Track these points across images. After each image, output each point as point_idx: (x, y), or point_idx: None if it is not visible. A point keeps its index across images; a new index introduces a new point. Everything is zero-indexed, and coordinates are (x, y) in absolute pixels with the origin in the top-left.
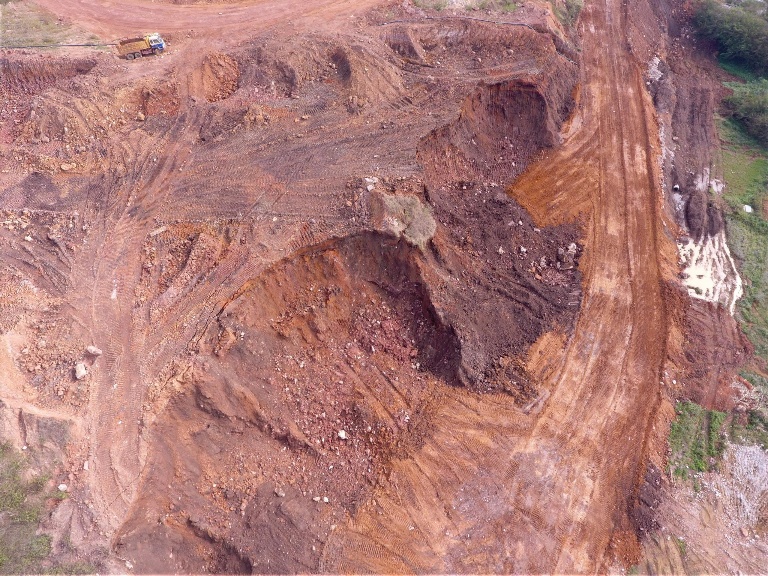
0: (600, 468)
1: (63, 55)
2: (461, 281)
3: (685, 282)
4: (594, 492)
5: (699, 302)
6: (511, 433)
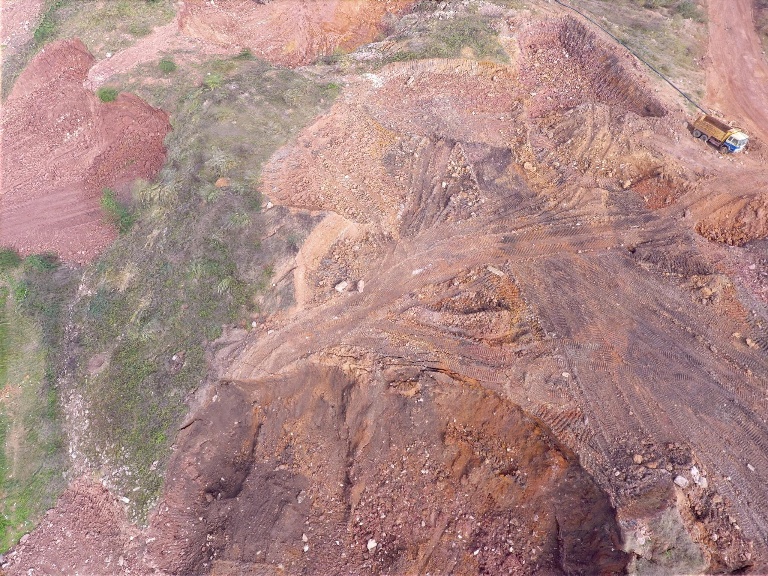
0: None
1: (655, 88)
2: None
3: None
4: None
5: None
6: None
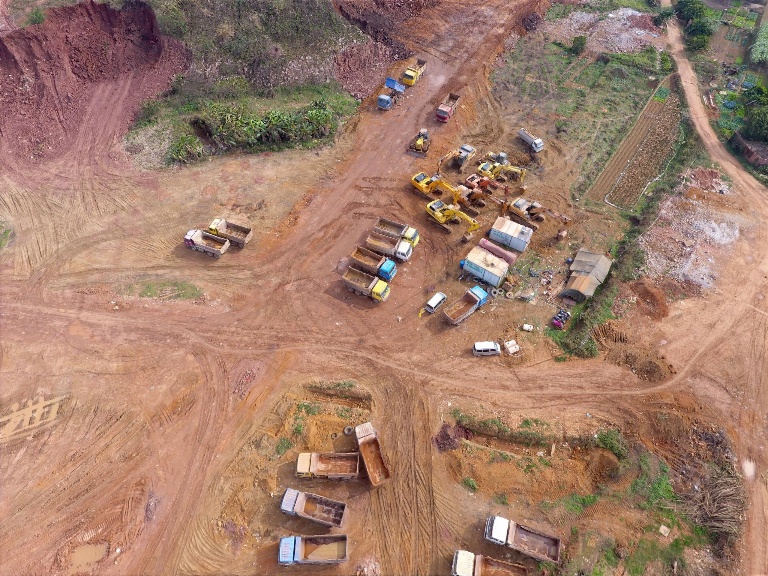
0: (513, 13)
1: None
2: None
3: None
4: (509, 17)
5: None
6: (474, 5)
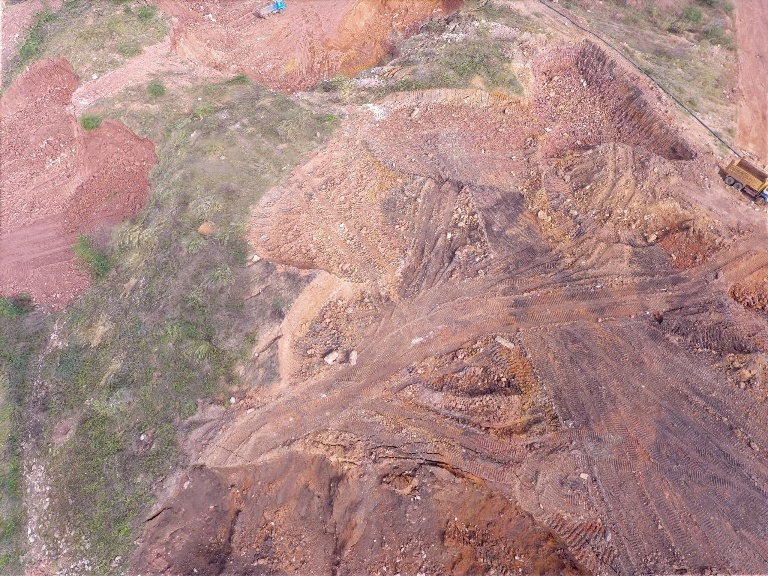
0: None
1: (682, 126)
2: None
3: None
4: None
5: None
6: None
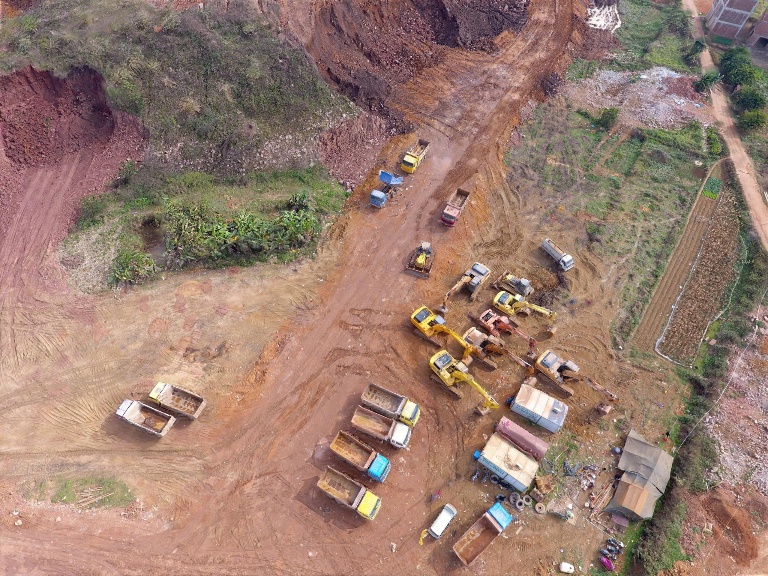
0: (529, 72)
1: None
2: (459, 3)
3: (588, 22)
4: (525, 78)
5: (595, 29)
6: (484, 62)
